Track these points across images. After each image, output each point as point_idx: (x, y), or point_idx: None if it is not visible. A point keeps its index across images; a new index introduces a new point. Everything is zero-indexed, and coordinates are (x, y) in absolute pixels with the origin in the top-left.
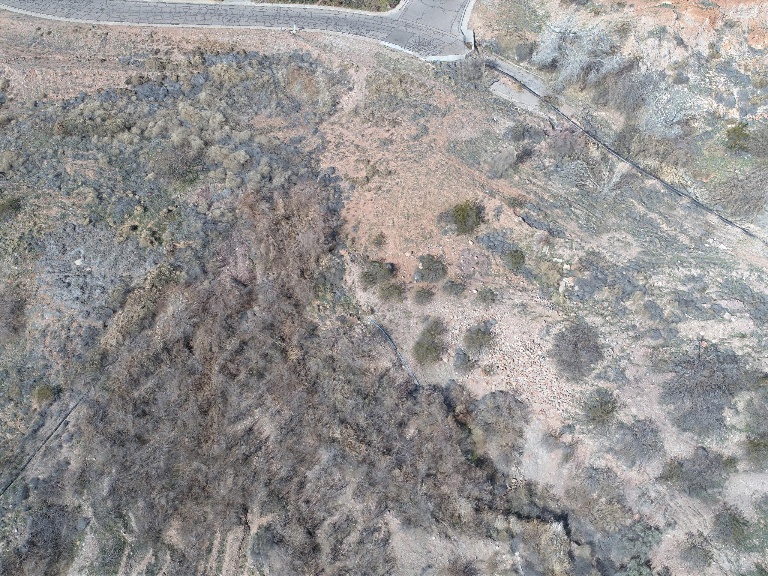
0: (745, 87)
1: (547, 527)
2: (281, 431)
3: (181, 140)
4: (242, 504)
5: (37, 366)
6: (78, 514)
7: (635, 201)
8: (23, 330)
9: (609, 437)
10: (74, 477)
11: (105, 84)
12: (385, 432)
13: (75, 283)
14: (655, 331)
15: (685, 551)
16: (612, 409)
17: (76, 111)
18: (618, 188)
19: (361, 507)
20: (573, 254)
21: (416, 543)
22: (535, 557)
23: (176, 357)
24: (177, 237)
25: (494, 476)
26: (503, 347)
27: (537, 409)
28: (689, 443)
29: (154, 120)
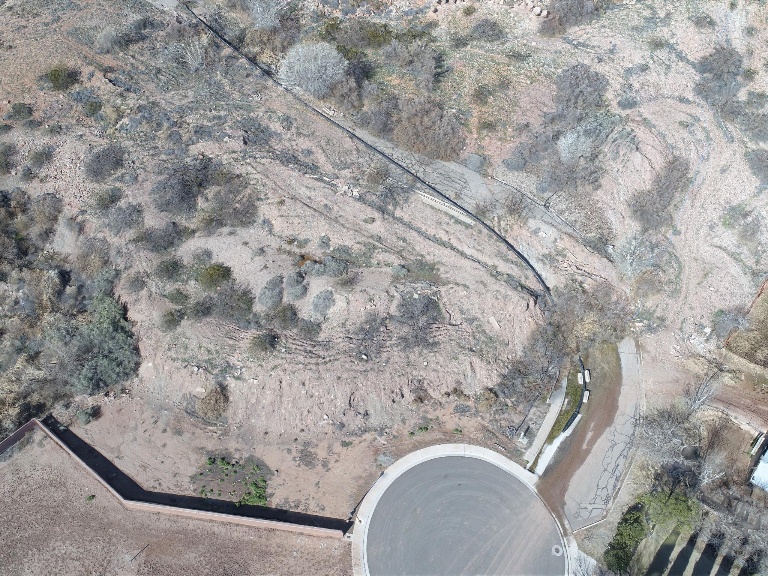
0: None
1: (45, 273)
2: None
3: None
4: None
5: None
6: None
7: (219, 73)
8: None
9: (110, 217)
10: None
11: None
12: None
13: None
14: (168, 149)
15: (132, 283)
16: (118, 200)
17: None
18: None
19: None
20: (137, 103)
21: None
22: None
23: None
24: None
25: (29, 248)
26: (57, 163)
27: (67, 202)
28: (163, 219)
29: None
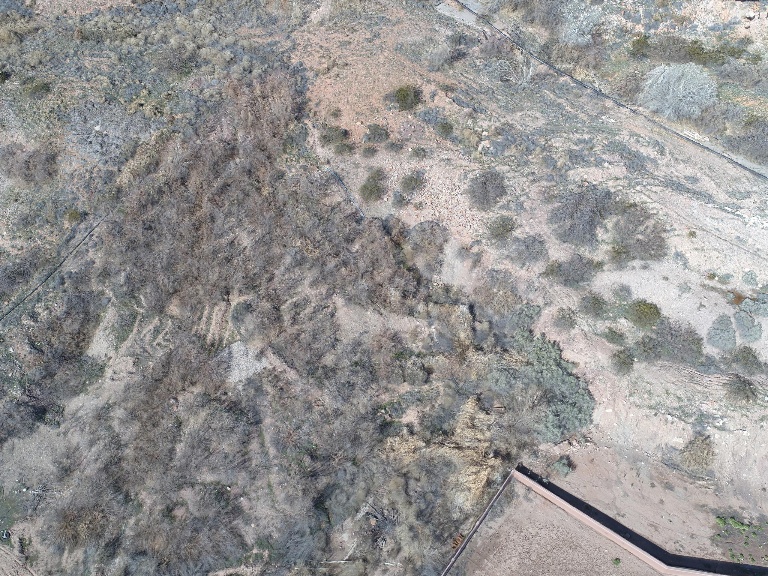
0: (649, 7)
1: (456, 308)
2: (256, 243)
3: (178, 44)
4: (225, 287)
5: (67, 199)
6: (102, 296)
7: (548, 91)
8: (56, 175)
9: (507, 248)
10: (98, 272)
11: (115, 3)
12: (335, 242)
13: (95, 142)
14: (549, 175)
15: (557, 320)
16: (511, 229)
17: (92, 23)
18: (536, 82)
19: (315, 292)
20: (491, 125)
21: (355, 315)
22: (445, 327)
23: (175, 190)
24: (175, 111)
25: (420, 280)
26: (430, 189)
27: (454, 231)
28: (568, 251)
29: (156, 30)
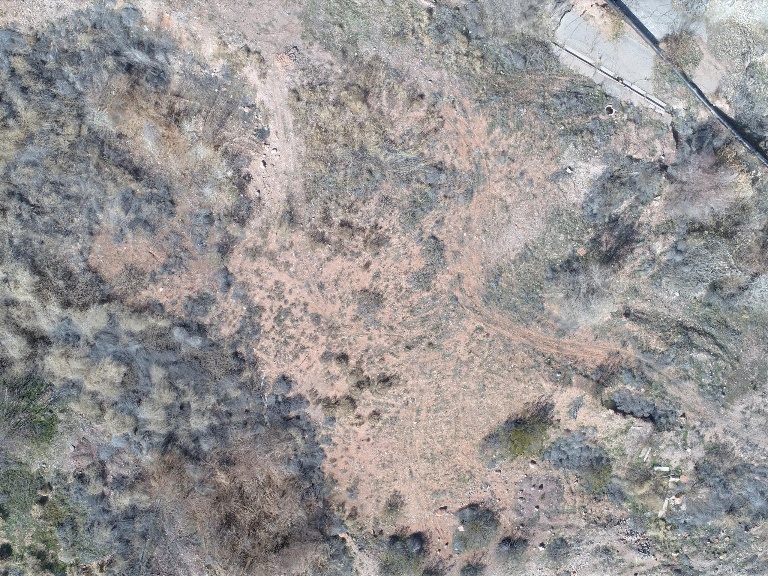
0: None
1: None
2: None
3: None
4: None
5: None
6: None
7: None
8: None
9: None
10: None
11: None
12: None
13: None
14: None
15: None
16: None
17: None
18: None
19: None
20: (686, 457)
21: None
22: None
23: None
24: (82, 557)
25: None
26: None
27: None
28: None
29: None
